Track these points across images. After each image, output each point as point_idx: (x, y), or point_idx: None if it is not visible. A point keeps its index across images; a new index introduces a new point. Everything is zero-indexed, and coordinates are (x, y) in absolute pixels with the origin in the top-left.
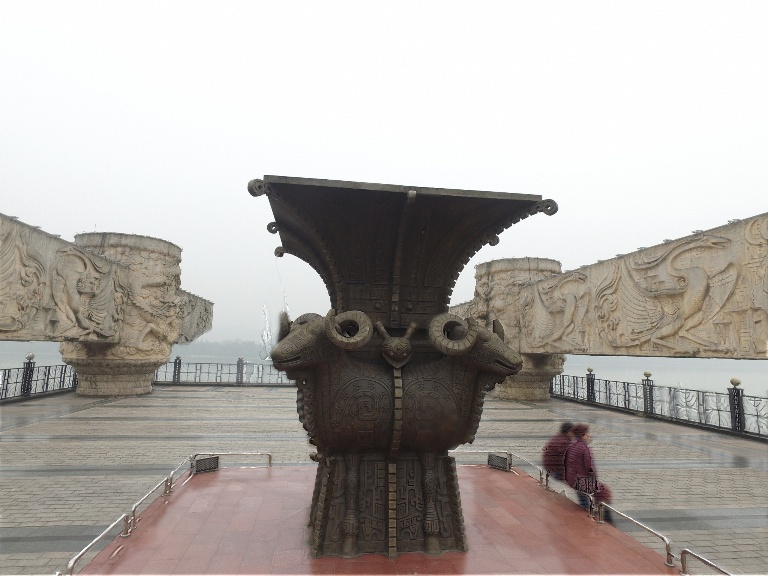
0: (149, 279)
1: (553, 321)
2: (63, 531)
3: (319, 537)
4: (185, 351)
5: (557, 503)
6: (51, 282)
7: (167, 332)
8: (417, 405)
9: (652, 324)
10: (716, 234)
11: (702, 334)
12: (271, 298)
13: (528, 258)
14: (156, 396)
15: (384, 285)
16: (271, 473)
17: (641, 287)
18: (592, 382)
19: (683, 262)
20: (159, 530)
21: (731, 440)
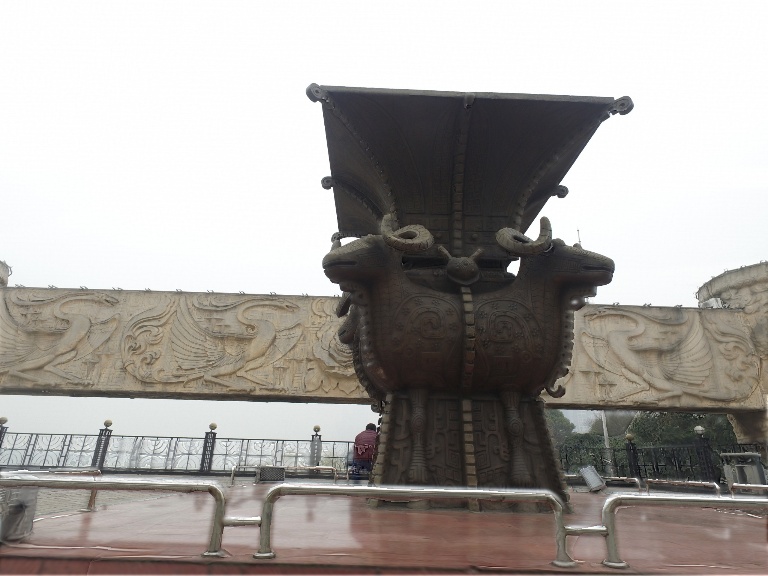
0: None
1: (31, 344)
2: None
3: None
4: None
5: None
6: None
7: None
8: None
9: (208, 362)
10: (289, 300)
11: (261, 375)
12: None
13: None
14: None
15: None
16: (153, 511)
17: (201, 326)
18: (1, 437)
19: (254, 314)
20: None
21: None
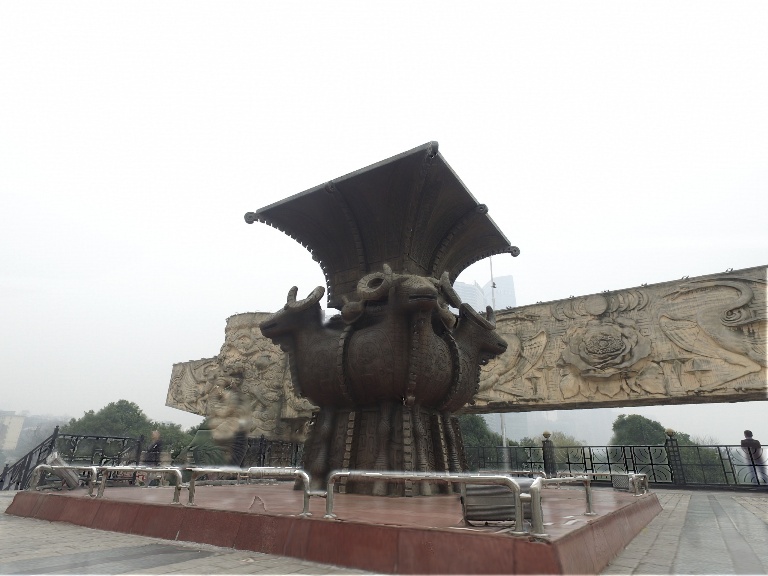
0: None
1: None
2: None
3: None
4: None
5: None
6: None
7: None
8: None
9: None
10: None
11: None
12: None
13: None
14: None
15: None
16: None
17: None
18: None
19: None
20: None
21: None
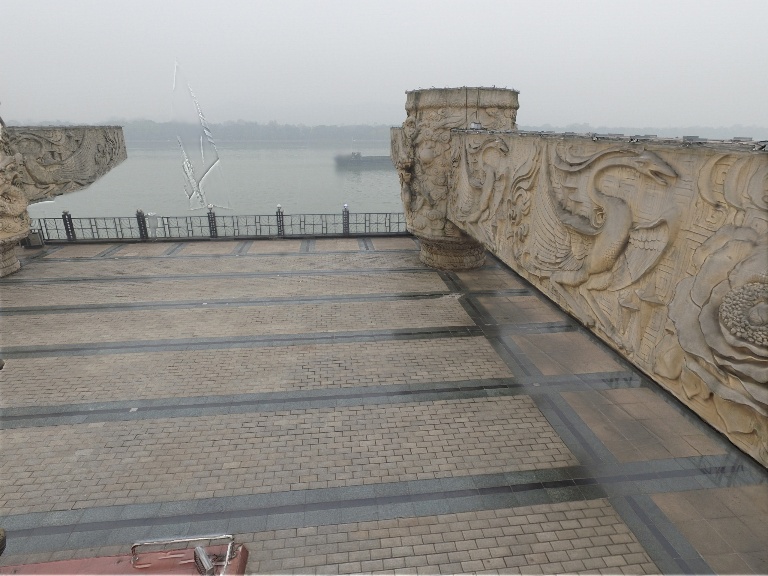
0: None
1: (473, 196)
2: None
3: None
4: (77, 201)
5: None
6: None
7: (2, 206)
8: None
9: (556, 259)
10: (662, 154)
11: (603, 305)
12: (181, 122)
13: (466, 89)
14: (17, 279)
15: None
16: None
17: (556, 197)
18: None
19: (609, 183)
20: None
21: (632, 392)
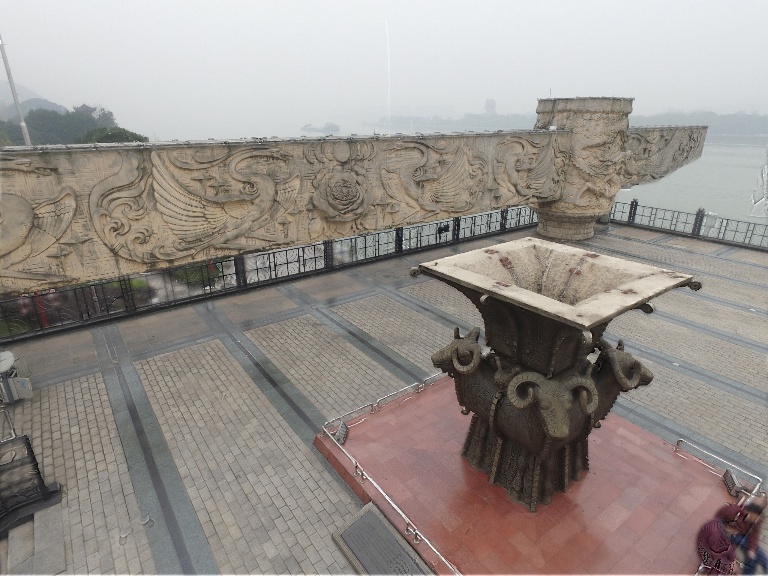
0: (589, 141)
1: None
2: (415, 370)
3: (464, 448)
4: (646, 192)
5: (695, 548)
6: (493, 170)
7: (604, 189)
8: (506, 419)
9: None
10: None
11: None
12: None
13: None
14: (591, 244)
15: (511, 331)
16: None
17: None
18: None
19: None
20: (431, 396)
21: None
